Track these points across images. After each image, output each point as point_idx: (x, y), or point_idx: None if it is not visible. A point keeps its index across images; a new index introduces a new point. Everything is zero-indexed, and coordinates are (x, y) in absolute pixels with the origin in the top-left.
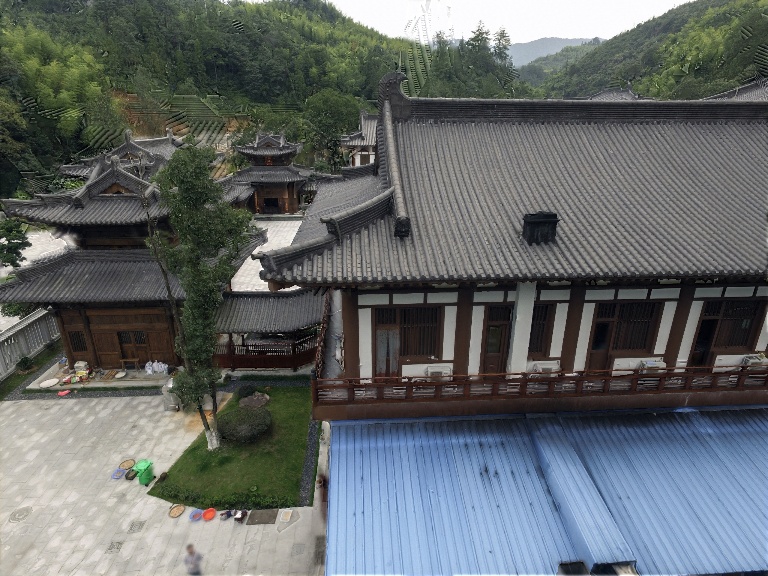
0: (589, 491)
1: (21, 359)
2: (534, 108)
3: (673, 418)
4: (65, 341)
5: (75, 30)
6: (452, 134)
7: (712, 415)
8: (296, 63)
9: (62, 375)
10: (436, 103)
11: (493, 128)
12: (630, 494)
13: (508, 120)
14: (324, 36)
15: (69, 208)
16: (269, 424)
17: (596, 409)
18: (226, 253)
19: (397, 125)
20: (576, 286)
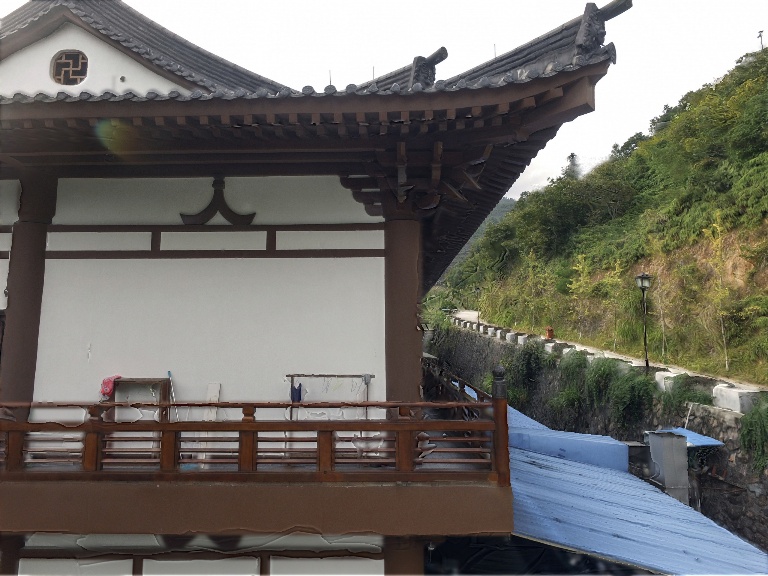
0: (546, 431)
1: None
2: None
3: None
4: None
5: None
6: None
7: None
8: None
9: None
10: None
11: None
12: None
13: None
14: None
15: None
16: None
17: None
18: None
19: None
20: None
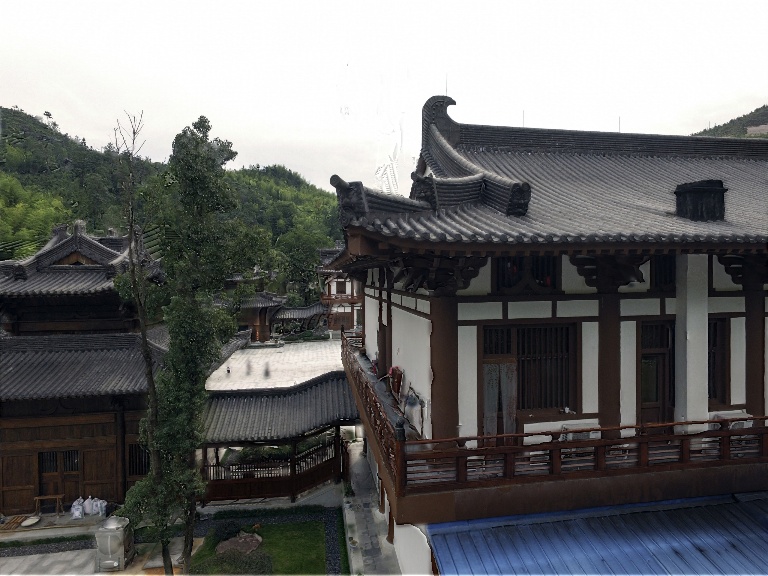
0: None
1: None
2: (593, 139)
3: None
4: None
5: (48, 184)
6: (511, 159)
7: None
8: (264, 215)
9: None
10: (487, 129)
11: (553, 157)
12: None
13: (567, 151)
14: (290, 197)
15: (6, 279)
16: (271, 575)
17: None
18: (224, 307)
19: None
20: (753, 290)
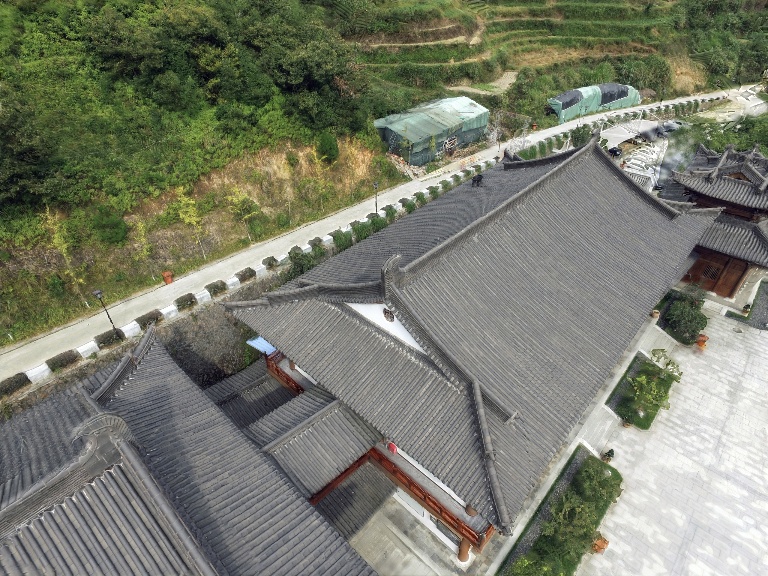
0: None
1: None
2: None
3: None
4: None
5: None
6: None
7: None
8: None
9: None
10: None
11: None
12: None
13: None
14: None
15: None
16: None
17: None
18: None
19: None
20: None
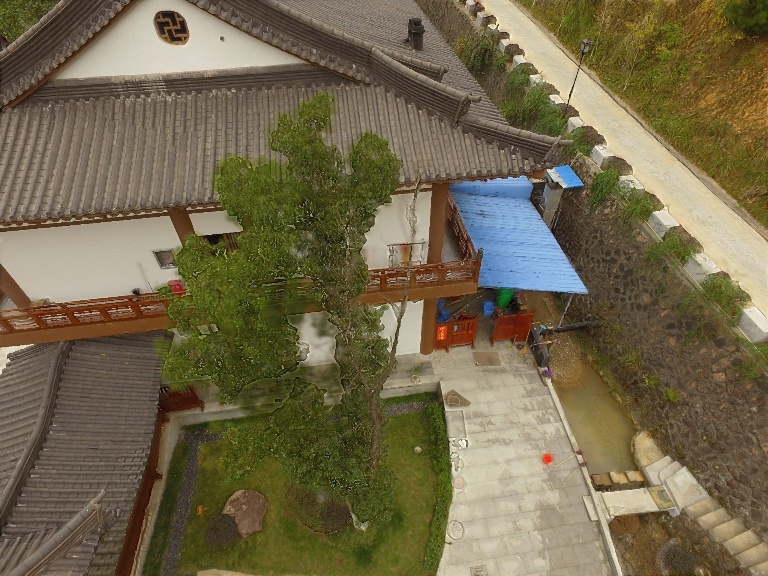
0: None
1: None
2: None
3: None
4: None
5: None
6: None
7: None
8: None
9: None
10: None
11: None
12: None
13: None
14: None
15: None
16: None
17: None
18: None
19: None
20: None
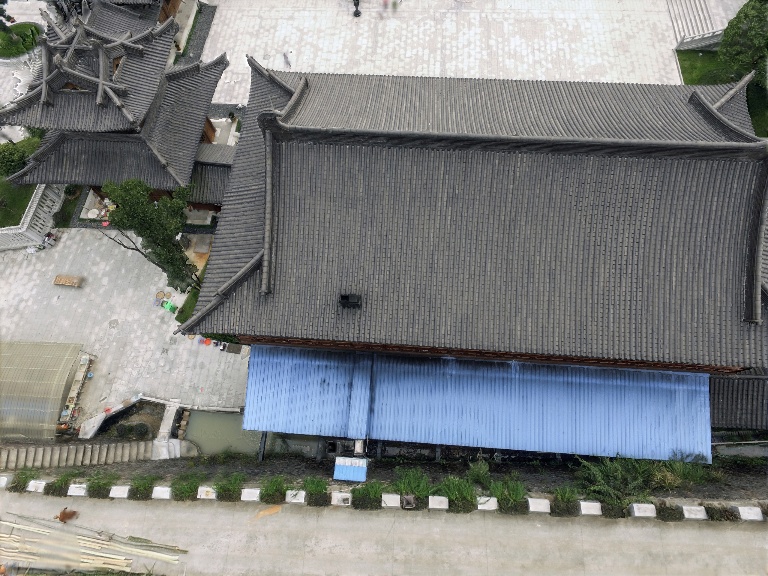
0: (364, 404)
1: (65, 190)
2: (401, 139)
3: (439, 362)
4: (90, 187)
5: None
6: (327, 160)
7: (462, 363)
8: None
9: (99, 206)
10: (311, 133)
11: (364, 153)
12: (388, 402)
13: (379, 145)
14: None
15: (42, 106)
16: None
17: (396, 353)
18: None
19: (280, 146)
20: None
